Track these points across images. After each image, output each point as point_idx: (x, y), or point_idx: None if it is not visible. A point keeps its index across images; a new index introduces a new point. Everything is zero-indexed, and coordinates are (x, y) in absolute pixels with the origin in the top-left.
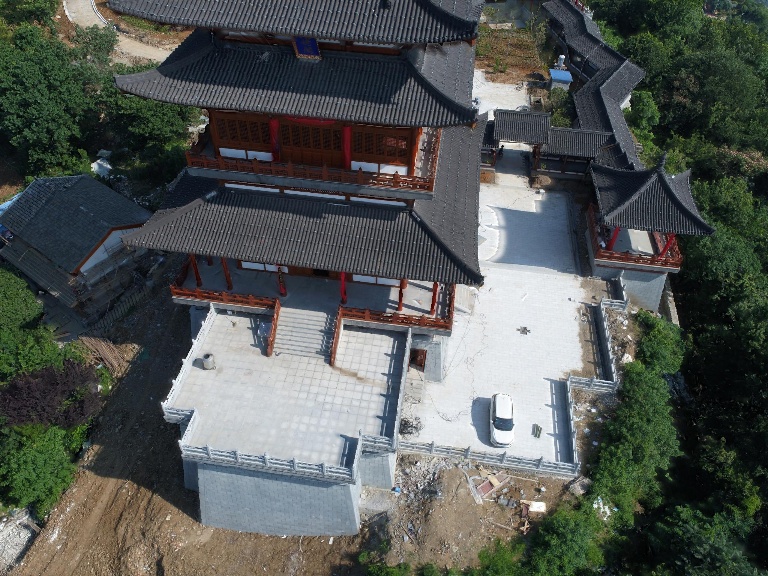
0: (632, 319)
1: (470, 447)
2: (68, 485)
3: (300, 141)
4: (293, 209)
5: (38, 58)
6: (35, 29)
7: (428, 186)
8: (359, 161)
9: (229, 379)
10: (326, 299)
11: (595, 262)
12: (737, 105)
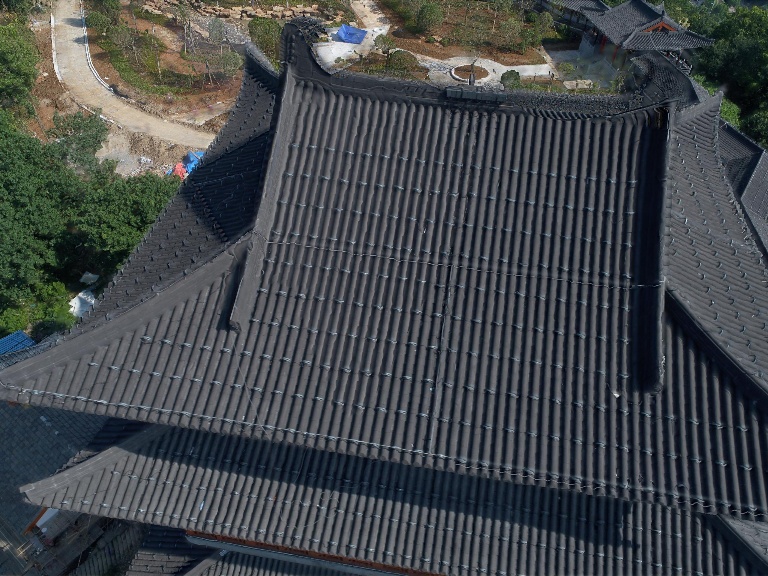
0: None
1: None
2: None
3: None
4: None
5: (3, 160)
6: (3, 115)
7: None
8: None
9: None
10: None
11: None
12: None
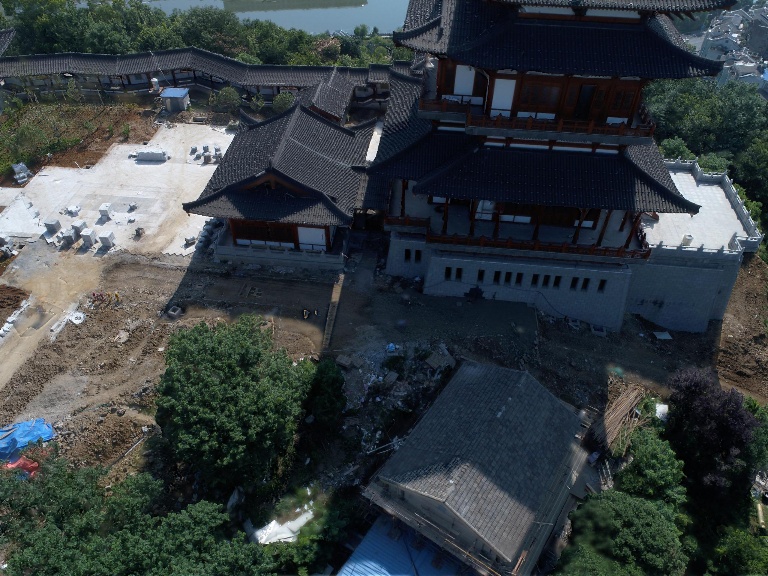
0: None
1: None
2: None
3: None
4: None
5: None
6: None
7: None
8: None
9: None
10: None
11: None
12: None
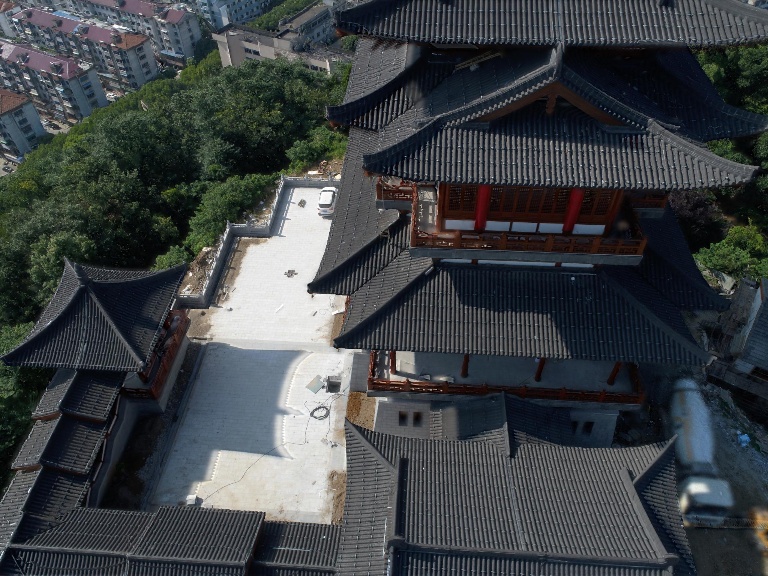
0: None
1: None
2: None
3: None
4: None
5: None
6: None
7: None
8: None
9: None
10: None
11: None
12: None
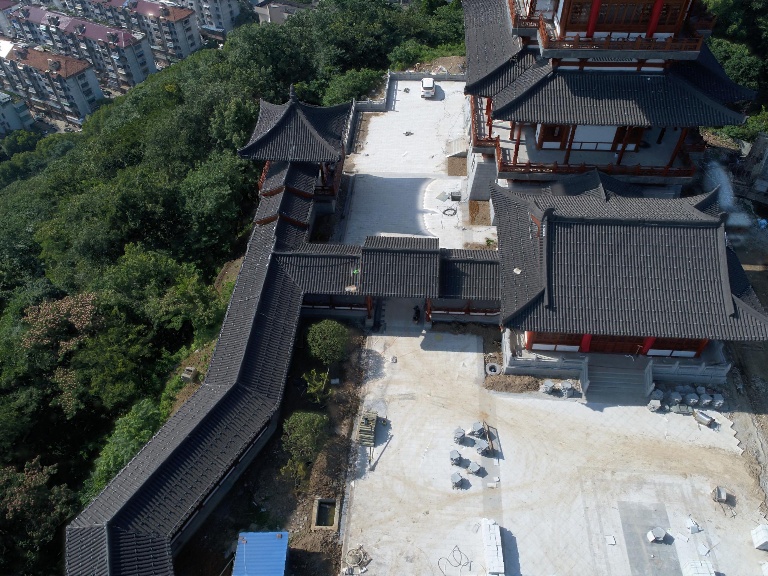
0: None
1: (447, 70)
2: None
3: None
4: None
5: None
6: None
7: None
8: None
9: None
10: None
11: None
12: None
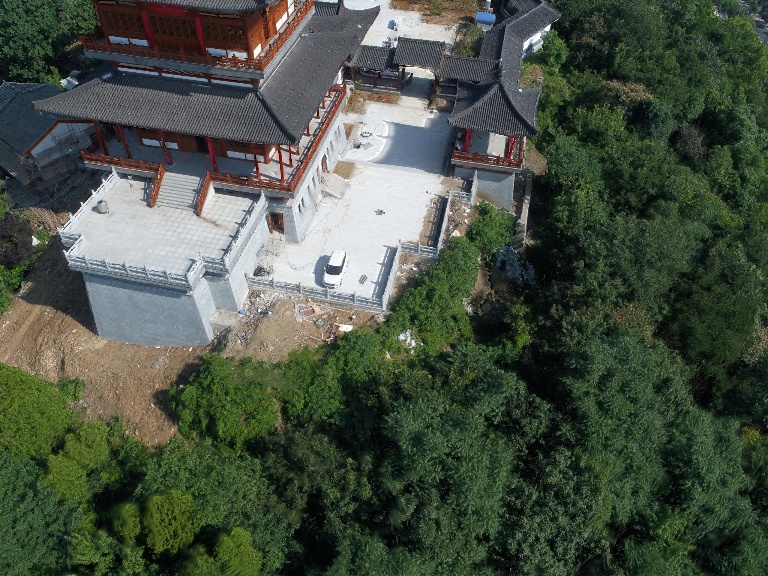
0: (475, 209)
1: (300, 283)
2: (6, 309)
3: (166, 30)
4: (168, 89)
5: None
6: None
7: (259, 67)
8: (211, 48)
9: (117, 220)
10: (203, 168)
11: (452, 162)
12: (639, 46)
